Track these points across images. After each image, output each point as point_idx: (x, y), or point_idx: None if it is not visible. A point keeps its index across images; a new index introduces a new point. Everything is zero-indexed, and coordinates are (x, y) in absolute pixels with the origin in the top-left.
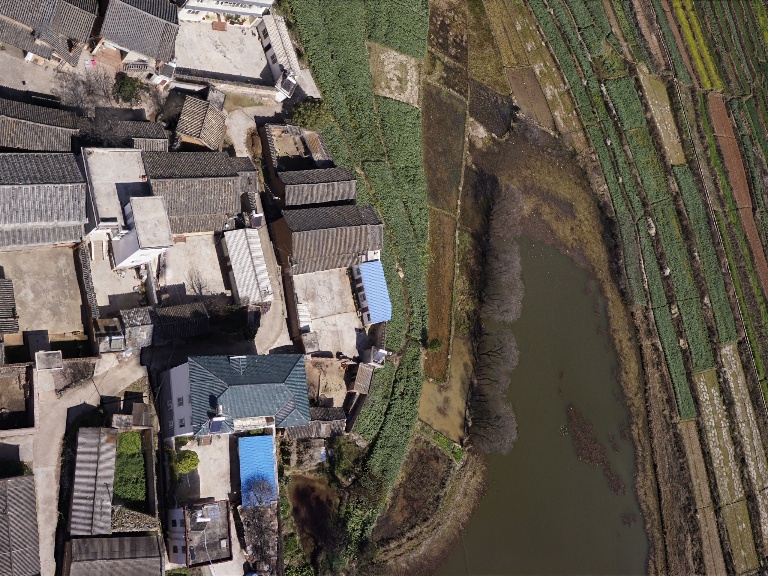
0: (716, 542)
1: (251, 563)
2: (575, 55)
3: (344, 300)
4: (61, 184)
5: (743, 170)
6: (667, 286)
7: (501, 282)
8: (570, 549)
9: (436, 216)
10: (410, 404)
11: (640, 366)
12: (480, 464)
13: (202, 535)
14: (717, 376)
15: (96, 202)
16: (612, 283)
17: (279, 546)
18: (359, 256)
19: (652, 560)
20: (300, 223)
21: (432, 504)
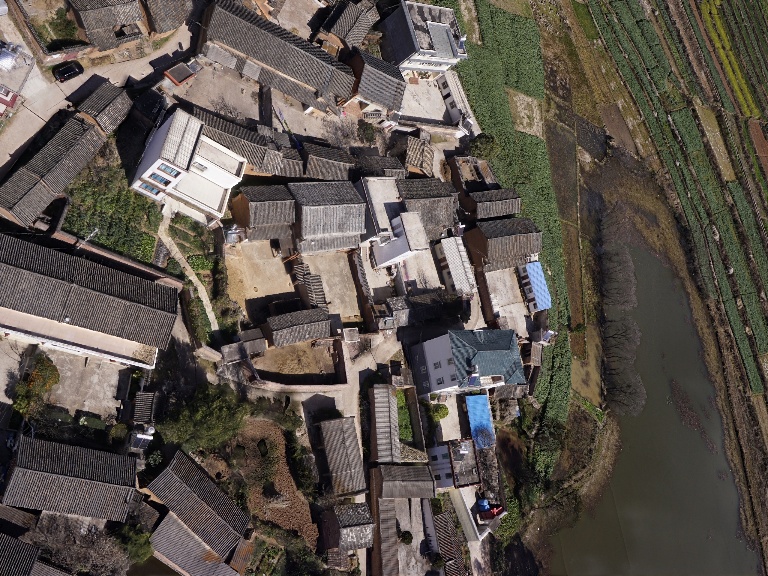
0: None
1: (479, 493)
2: (646, 92)
3: (514, 293)
4: (352, 204)
5: None
6: (732, 283)
7: (617, 279)
8: (684, 496)
9: (564, 227)
10: (566, 375)
11: (718, 349)
12: (615, 425)
13: (461, 464)
14: None
15: None
16: (691, 281)
17: (500, 479)
18: (526, 258)
19: (742, 508)
20: (490, 232)
21: (587, 455)
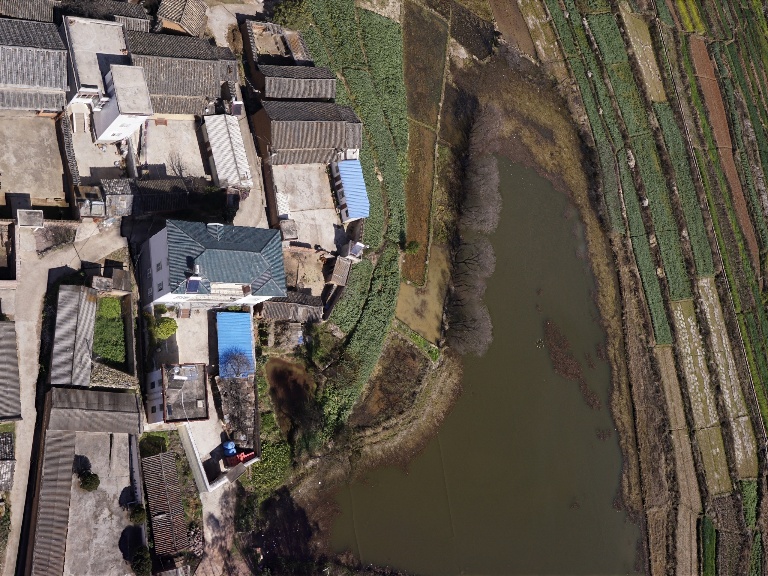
0: (690, 463)
1: (228, 433)
2: None
3: (323, 197)
4: (43, 49)
5: (724, 112)
6: (646, 216)
7: (479, 195)
8: (544, 455)
9: (416, 128)
10: (387, 301)
11: (617, 291)
12: (456, 366)
13: (179, 394)
14: (694, 307)
15: (77, 69)
16: (591, 209)
17: (256, 417)
18: (338, 153)
19: (626, 474)
20: (279, 113)
21: (408, 399)
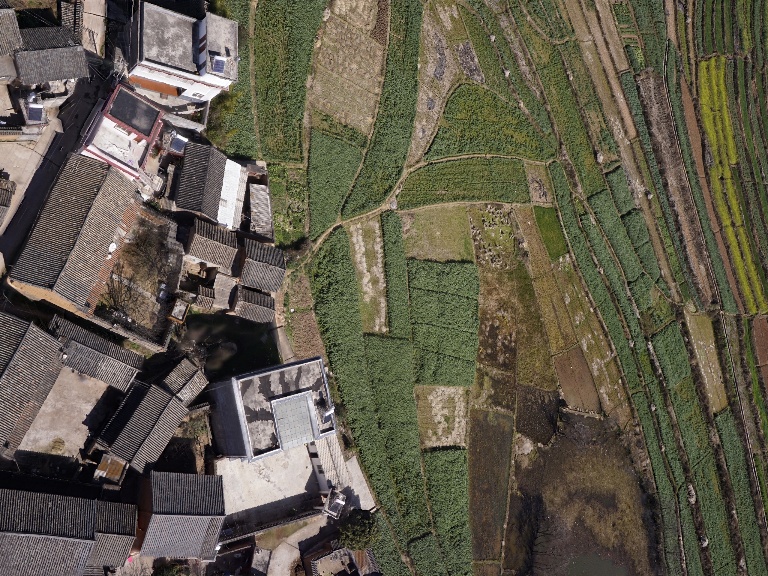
0: None
1: None
2: (623, 315)
3: None
4: None
5: None
6: (705, 558)
7: None
8: None
9: (480, 571)
10: None
11: None
12: None
13: None
14: None
15: None
16: (651, 572)
17: None
18: None
19: None
20: None
21: None
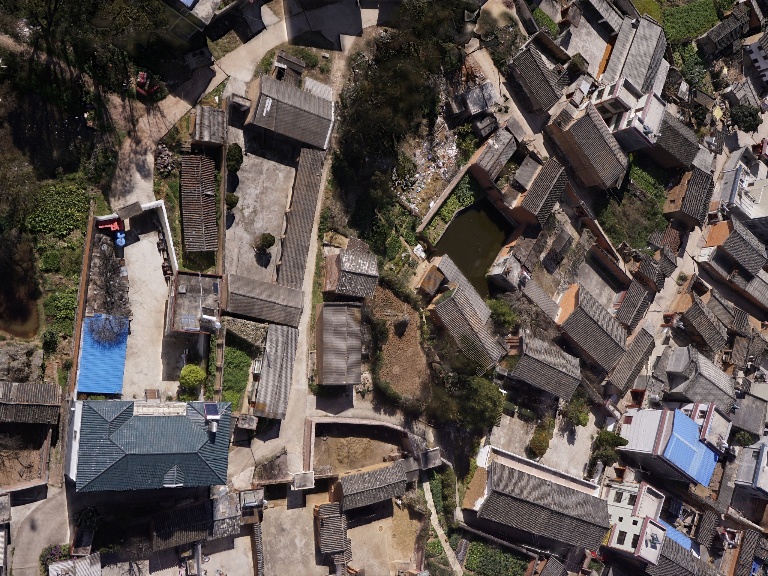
0: None
1: (113, 256)
2: None
3: None
4: None
5: None
6: None
7: None
8: None
9: None
10: None
11: None
12: None
13: (203, 303)
14: None
15: None
16: None
17: None
18: None
19: None
20: None
21: None
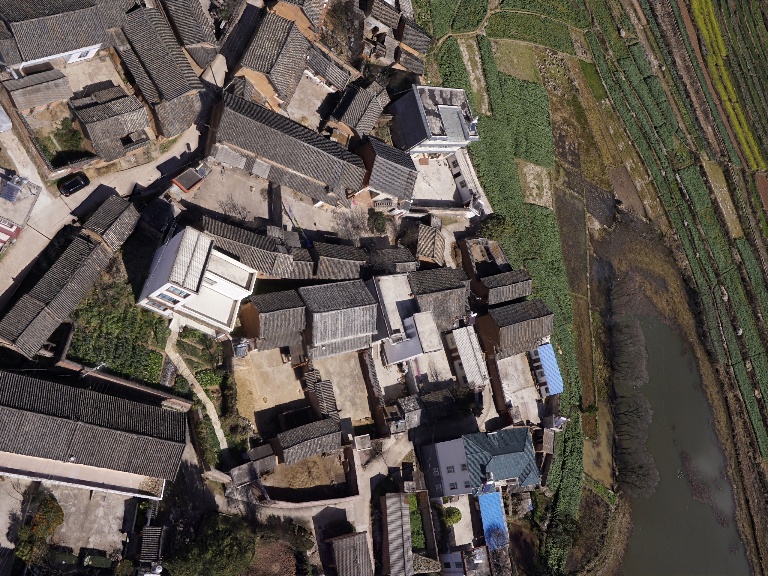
0: None
1: None
2: (654, 150)
3: (526, 377)
4: (364, 306)
5: None
6: (741, 344)
7: (628, 352)
8: (696, 575)
9: (575, 300)
10: (578, 459)
11: (727, 415)
12: (627, 506)
13: (475, 574)
14: None
15: None
16: (700, 345)
17: None
18: (538, 341)
19: None
20: (502, 319)
21: (599, 542)
